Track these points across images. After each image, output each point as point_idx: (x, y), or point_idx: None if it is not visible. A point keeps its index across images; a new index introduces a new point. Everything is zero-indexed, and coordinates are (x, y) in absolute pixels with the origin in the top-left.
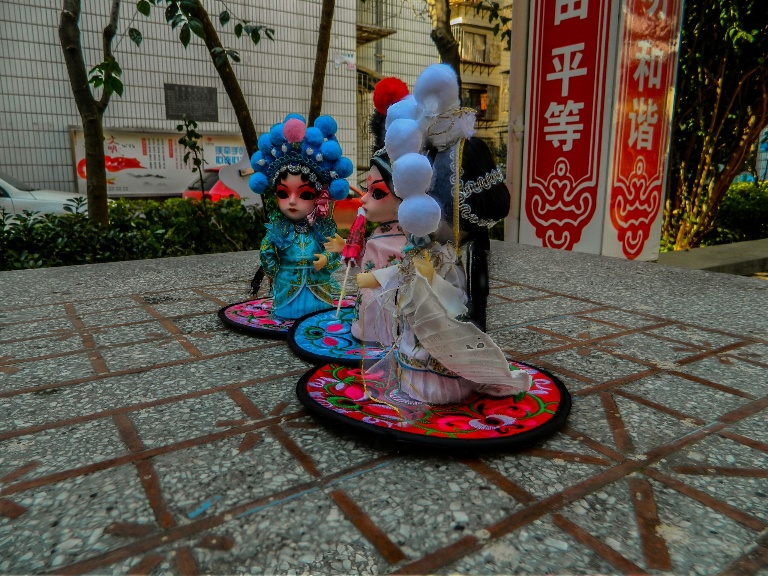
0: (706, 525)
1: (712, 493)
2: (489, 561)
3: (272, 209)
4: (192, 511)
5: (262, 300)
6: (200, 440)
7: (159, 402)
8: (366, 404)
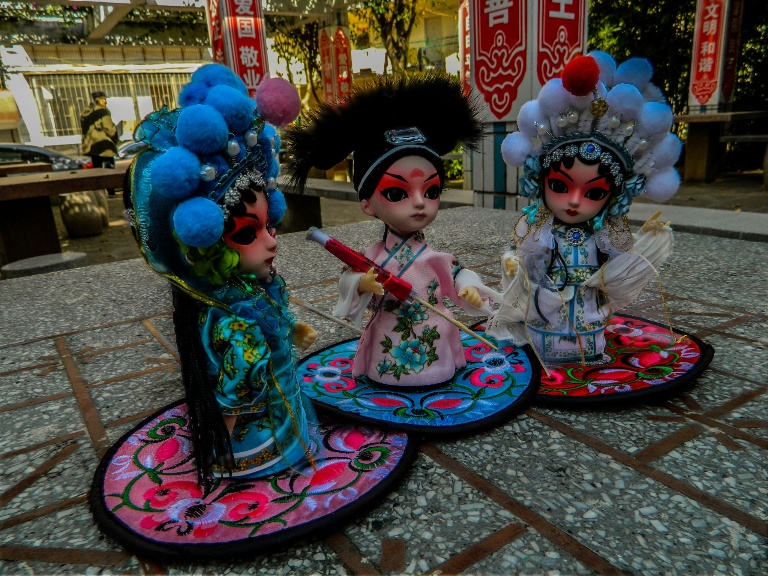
0: (681, 305)
1: None
2: None
3: None
4: None
5: (133, 511)
6: None
7: (732, 511)
8: (640, 367)
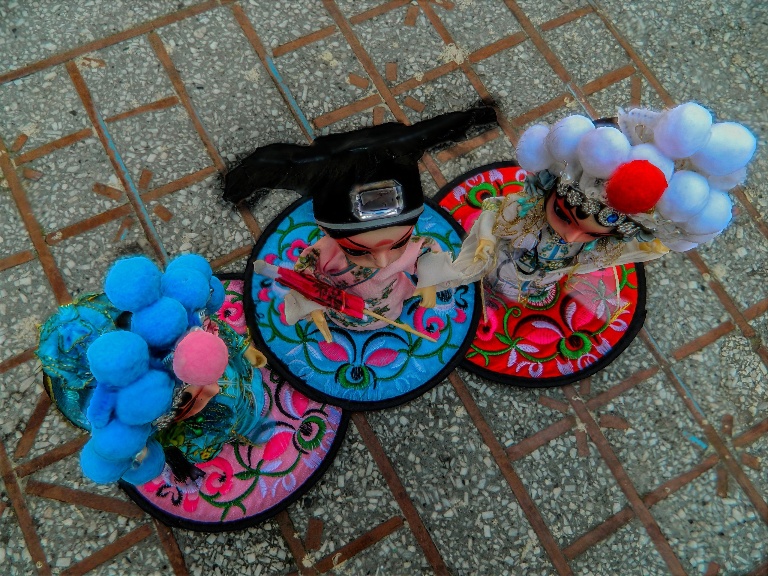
0: None
1: None
2: (726, 279)
3: None
4: (701, 447)
5: None
6: (614, 463)
7: (540, 524)
8: (569, 327)
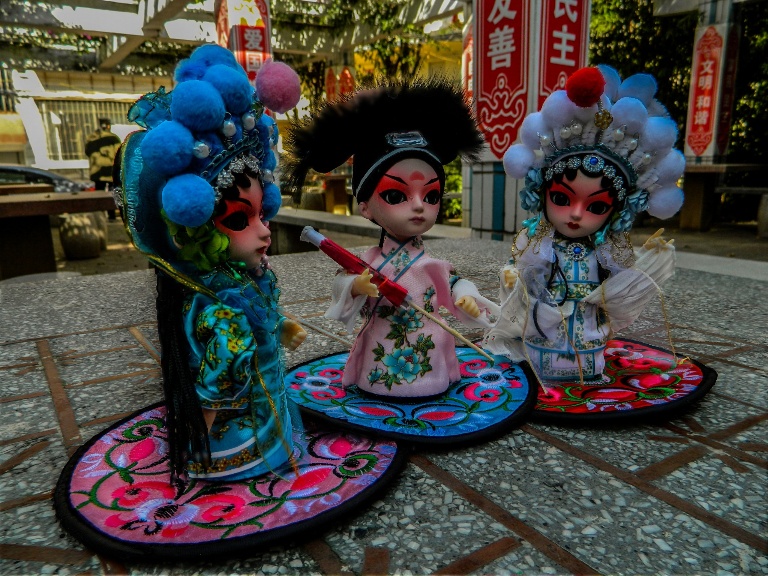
0: None
1: (646, 328)
2: None
3: (226, 257)
4: None
5: (99, 509)
6: None
7: (741, 532)
8: (640, 388)
